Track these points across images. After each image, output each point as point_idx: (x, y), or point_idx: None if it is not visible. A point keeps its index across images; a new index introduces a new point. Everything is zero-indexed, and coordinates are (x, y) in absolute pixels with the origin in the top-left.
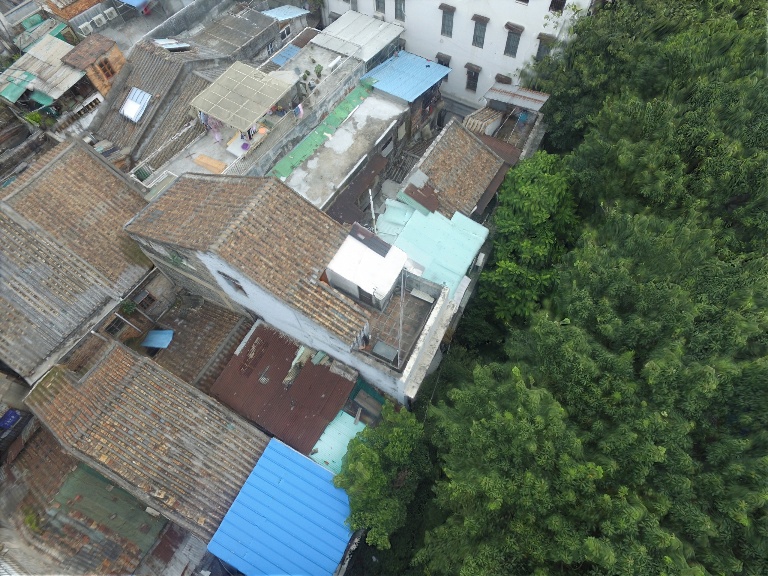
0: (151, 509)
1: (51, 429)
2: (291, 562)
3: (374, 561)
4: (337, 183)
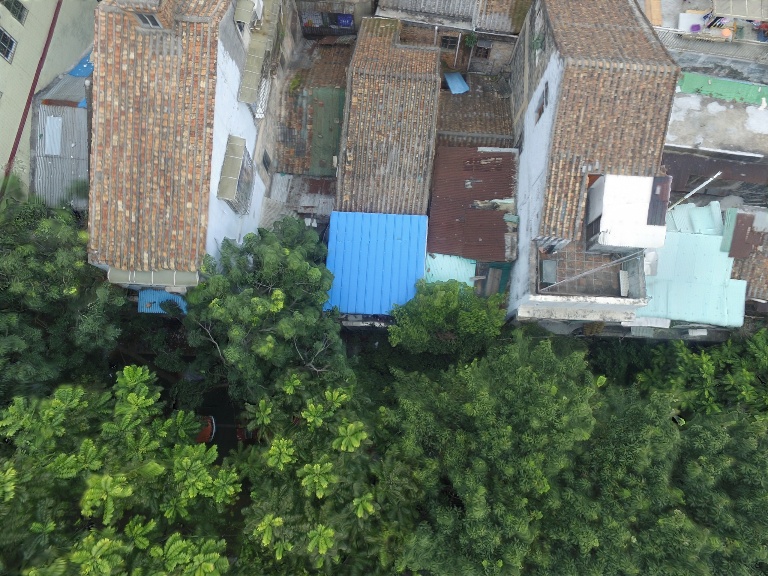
0: (336, 159)
1: (356, 50)
2: (350, 277)
3: (375, 344)
4: (706, 145)
